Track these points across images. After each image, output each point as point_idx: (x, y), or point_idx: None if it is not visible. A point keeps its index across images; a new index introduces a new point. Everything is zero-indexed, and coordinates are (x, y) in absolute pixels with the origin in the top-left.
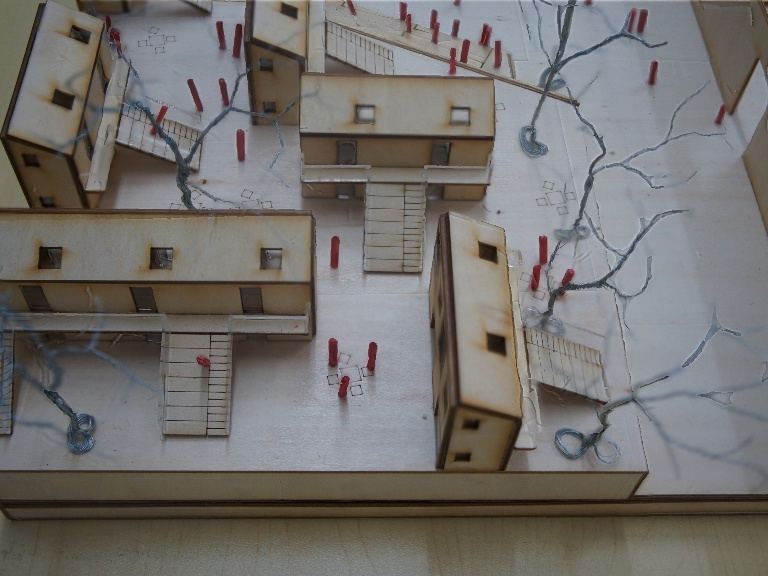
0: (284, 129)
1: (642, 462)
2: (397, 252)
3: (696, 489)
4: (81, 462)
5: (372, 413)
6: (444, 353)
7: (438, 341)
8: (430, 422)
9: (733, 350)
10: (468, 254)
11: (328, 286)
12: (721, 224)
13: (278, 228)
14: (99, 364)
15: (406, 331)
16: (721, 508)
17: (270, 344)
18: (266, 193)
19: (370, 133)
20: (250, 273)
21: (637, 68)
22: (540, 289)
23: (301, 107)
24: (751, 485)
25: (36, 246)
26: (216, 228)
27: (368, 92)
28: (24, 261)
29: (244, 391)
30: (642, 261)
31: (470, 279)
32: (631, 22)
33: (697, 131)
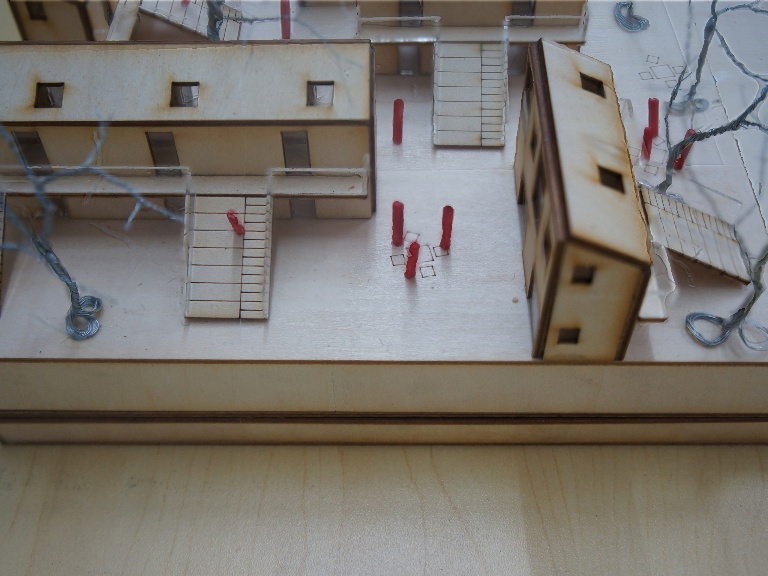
0: (336, 10)
1: None
2: (473, 122)
3: None
4: (82, 349)
5: (448, 296)
6: (540, 207)
7: (532, 196)
8: (522, 306)
9: None
10: (568, 83)
11: (390, 162)
12: None
13: (329, 57)
14: (110, 244)
15: (487, 208)
16: None
17: (320, 222)
18: None
19: None
20: (294, 110)
21: None
22: (652, 163)
23: None
24: None
25: (33, 82)
26: (252, 59)
27: None
28: (17, 99)
29: (287, 272)
30: None
31: (573, 107)
32: None
33: None
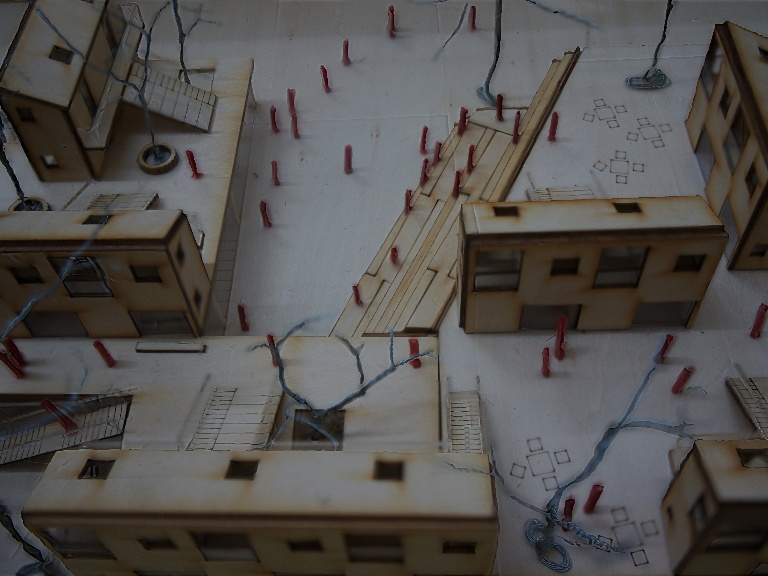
0: None
1: None
2: None
3: None
4: None
5: None
6: None
7: None
8: None
9: None
10: None
11: None
12: (654, 4)
13: None
14: None
15: None
16: None
17: None
18: None
19: None
20: None
21: None
22: None
23: None
24: None
25: None
26: None
27: None
28: None
29: None
30: None
31: None
32: None
33: (537, 6)
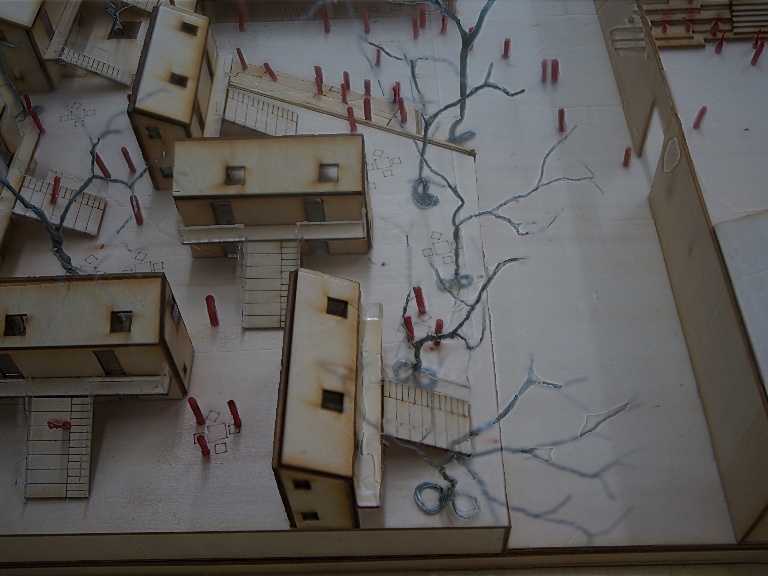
0: None
1: (503, 516)
2: (274, 308)
3: (574, 541)
4: None
5: (233, 471)
6: None
7: None
8: None
9: (624, 394)
10: (314, 310)
11: (206, 344)
12: (621, 266)
13: (128, 291)
14: None
15: (277, 387)
16: (606, 560)
17: (142, 404)
18: (159, 255)
19: (240, 193)
20: (100, 336)
21: (549, 116)
22: (416, 340)
23: (174, 171)
24: (632, 536)
25: None
26: (69, 293)
27: (239, 154)
28: None
29: (110, 452)
30: (537, 306)
31: (312, 335)
32: (544, 72)
33: (604, 175)
